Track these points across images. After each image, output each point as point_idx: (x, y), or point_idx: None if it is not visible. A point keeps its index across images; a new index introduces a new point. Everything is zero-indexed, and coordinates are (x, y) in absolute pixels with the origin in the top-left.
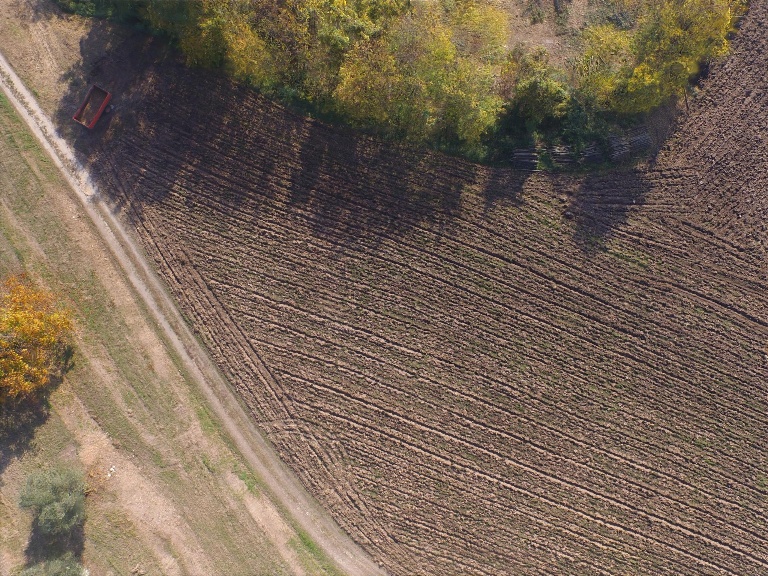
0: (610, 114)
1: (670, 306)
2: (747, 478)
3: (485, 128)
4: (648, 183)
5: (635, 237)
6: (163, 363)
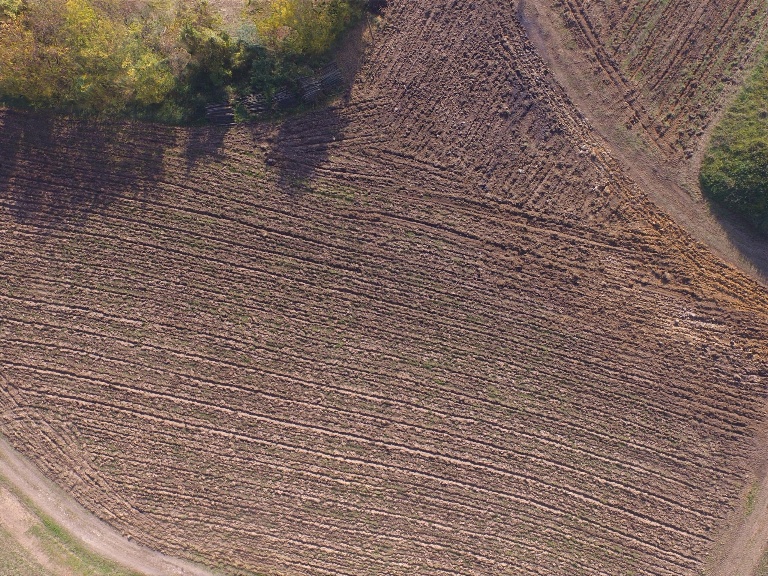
0: (301, 57)
1: (381, 235)
2: (478, 391)
3: (175, 89)
4: (345, 118)
5: (339, 173)
6: None
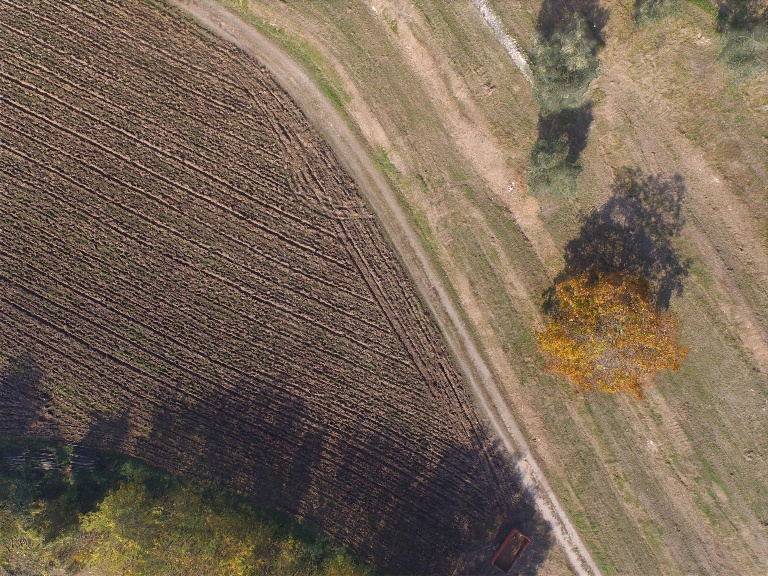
0: None
1: None
2: None
3: None
4: None
5: None
6: (461, 286)
